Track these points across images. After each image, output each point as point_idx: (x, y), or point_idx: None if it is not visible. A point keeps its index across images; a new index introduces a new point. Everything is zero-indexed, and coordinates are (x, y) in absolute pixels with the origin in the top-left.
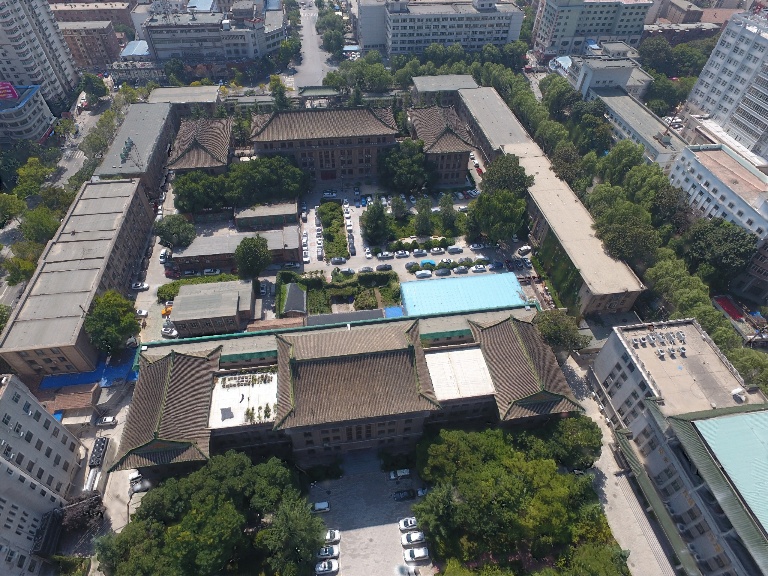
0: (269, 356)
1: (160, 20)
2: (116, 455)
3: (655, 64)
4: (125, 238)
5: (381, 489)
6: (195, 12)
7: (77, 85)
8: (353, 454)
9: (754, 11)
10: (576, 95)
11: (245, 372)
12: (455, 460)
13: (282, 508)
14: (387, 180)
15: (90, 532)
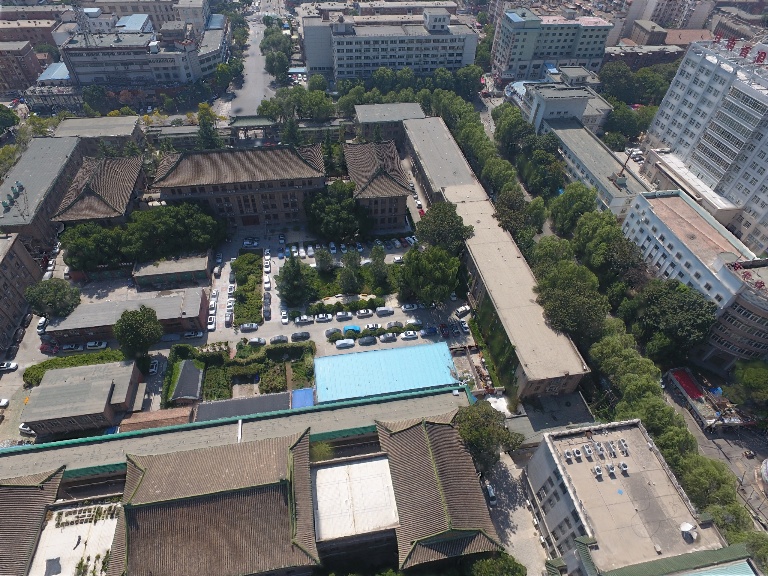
0: None
1: None
2: None
3: (616, 90)
4: None
5: None
6: (122, 32)
7: None
8: None
9: (719, 32)
10: (528, 128)
11: (89, 503)
12: None
13: None
14: (315, 227)
15: None
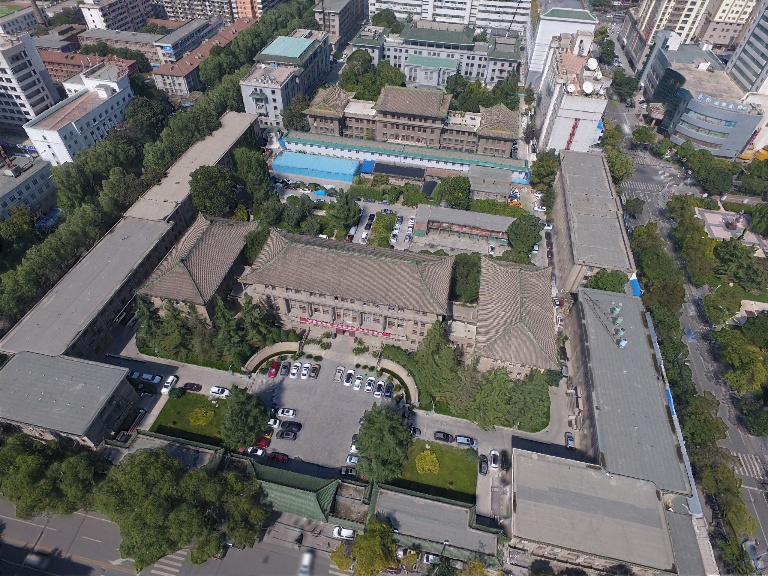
0: None
1: None
2: None
3: None
4: None
5: None
6: None
7: None
8: None
9: None
10: None
11: None
12: None
13: None
14: None
15: None
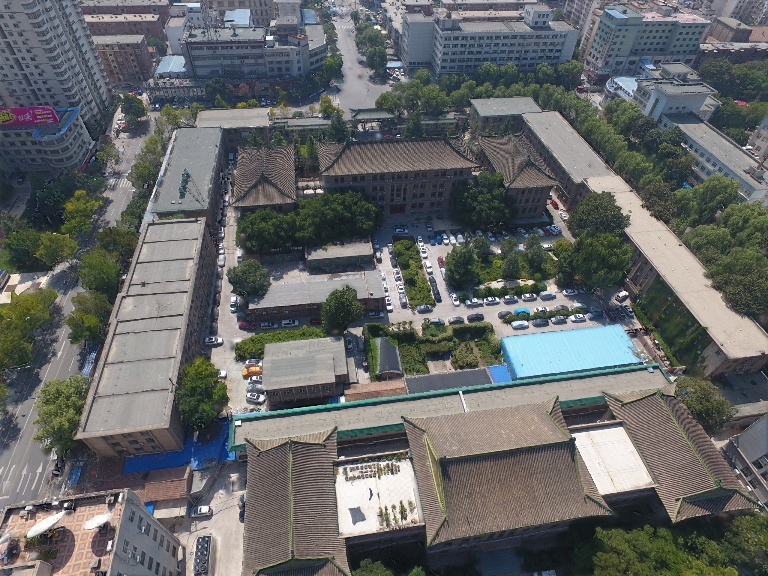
0: (378, 431)
1: (199, 35)
2: (241, 575)
3: (717, 87)
4: (197, 288)
5: None
6: (235, 27)
7: (111, 104)
8: (488, 551)
9: None
10: (650, 122)
11: (368, 460)
12: (625, 571)
13: None
14: (463, 216)
15: None
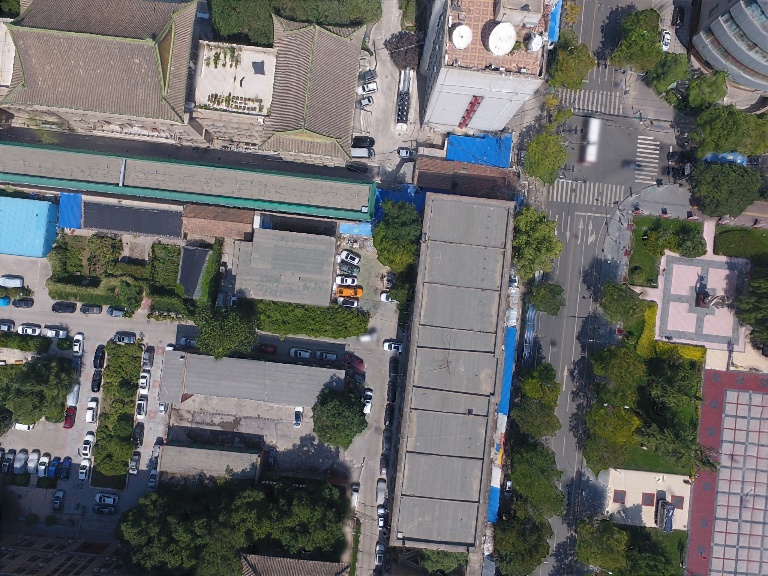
0: None
1: None
2: None
3: None
4: None
5: None
6: None
7: None
8: None
9: None
10: None
11: None
12: None
13: None
14: None
15: None
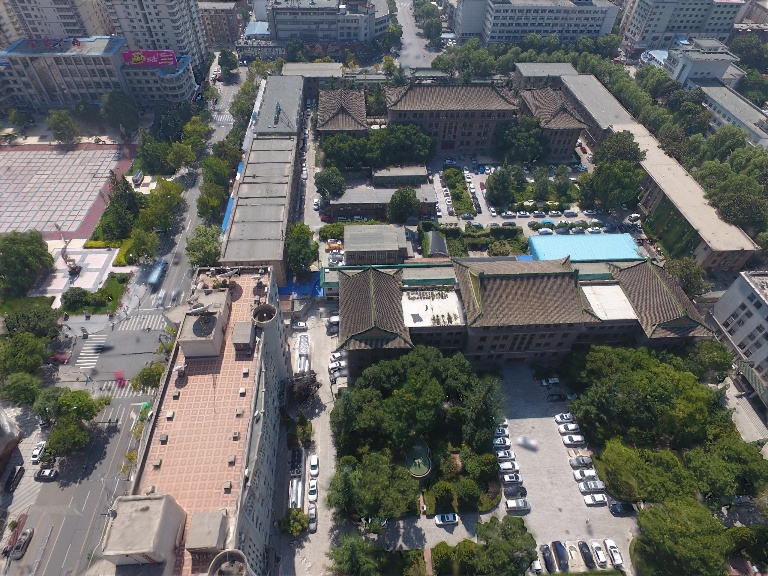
0: (430, 284)
1: (283, 3)
2: (339, 339)
3: (746, 60)
4: (292, 185)
5: (535, 392)
6: None
7: (207, 59)
8: (509, 364)
9: None
10: (676, 84)
11: (424, 289)
12: (609, 366)
13: (470, 391)
14: (503, 151)
15: (305, 403)
